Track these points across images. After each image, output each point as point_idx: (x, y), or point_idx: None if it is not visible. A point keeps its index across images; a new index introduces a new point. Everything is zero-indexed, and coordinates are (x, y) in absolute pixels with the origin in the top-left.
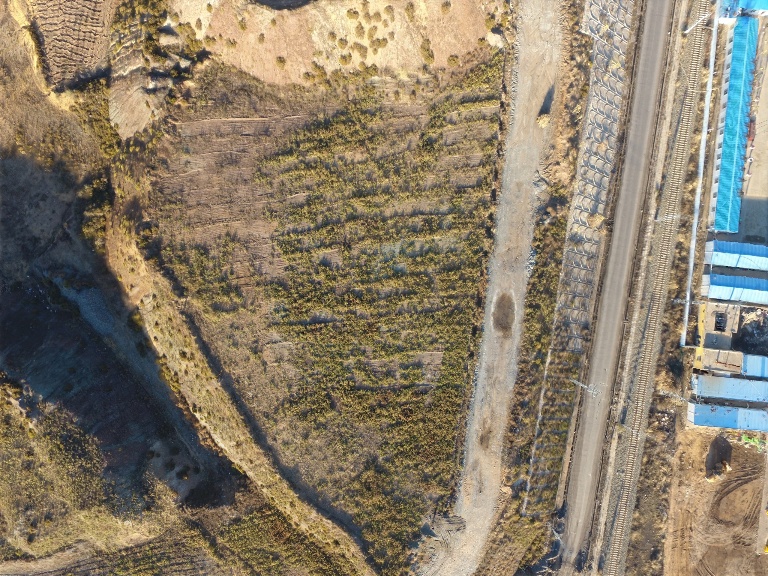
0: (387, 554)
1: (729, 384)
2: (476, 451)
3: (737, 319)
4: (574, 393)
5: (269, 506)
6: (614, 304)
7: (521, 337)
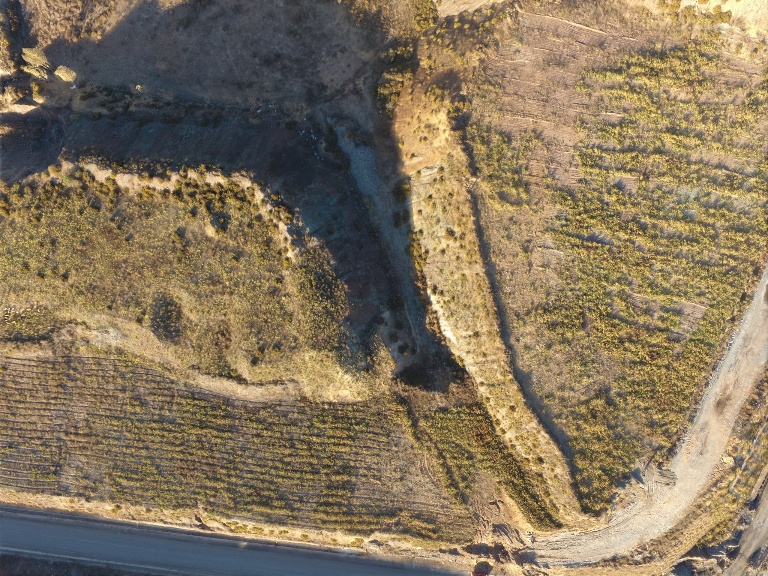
0: (592, 485)
1: None
2: (709, 413)
3: None
4: None
5: (480, 405)
6: None
7: None
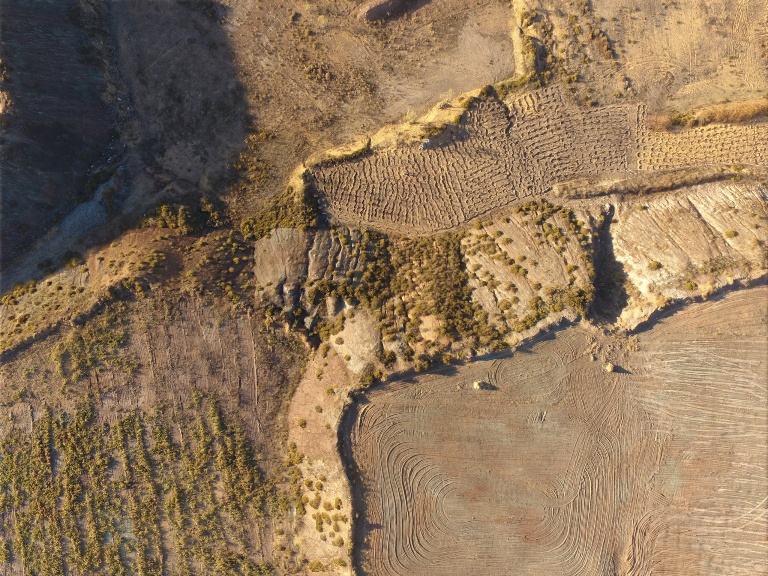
0: None
1: None
2: None
3: None
4: None
5: None
6: None
7: None
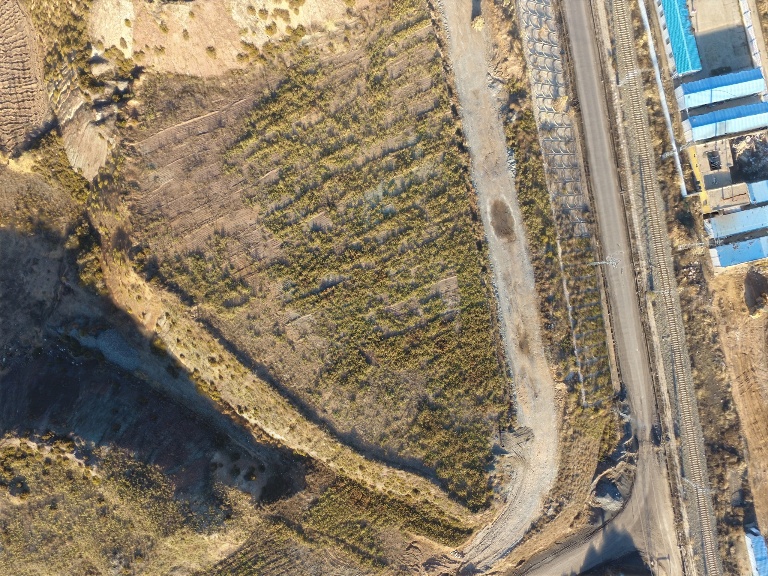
0: (467, 485)
1: (742, 217)
2: (519, 359)
3: (729, 152)
4: (596, 277)
5: (341, 478)
6: (606, 179)
7: (526, 236)
